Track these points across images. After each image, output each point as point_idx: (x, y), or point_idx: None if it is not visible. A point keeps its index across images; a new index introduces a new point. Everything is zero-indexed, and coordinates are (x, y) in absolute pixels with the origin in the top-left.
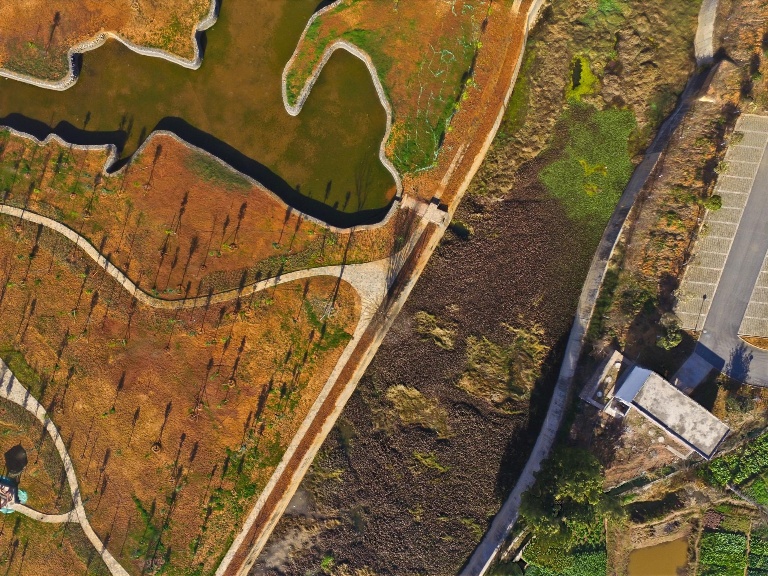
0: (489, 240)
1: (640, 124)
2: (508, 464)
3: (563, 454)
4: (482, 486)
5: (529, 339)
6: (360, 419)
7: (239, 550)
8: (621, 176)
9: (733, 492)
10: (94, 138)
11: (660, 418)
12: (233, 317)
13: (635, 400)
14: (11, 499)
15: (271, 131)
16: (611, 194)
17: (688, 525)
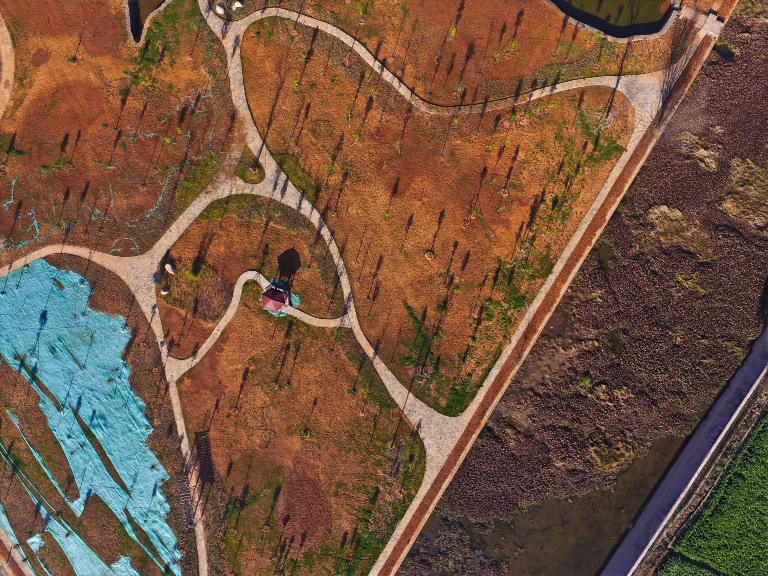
0: (756, 61)
1: None
2: None
3: None
4: (744, 309)
5: None
6: (621, 240)
7: (507, 362)
8: None
9: None
10: None
11: None
12: (508, 125)
13: None
14: (285, 301)
15: None
16: None
17: None
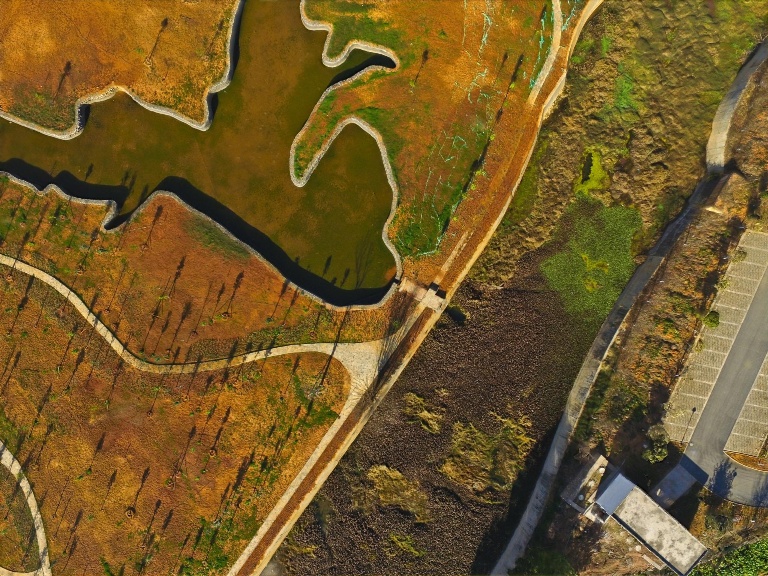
0: (485, 327)
1: (645, 224)
2: (484, 554)
3: (539, 557)
4: (456, 574)
5: (516, 430)
6: (339, 496)
7: None
8: (622, 274)
9: None
10: (95, 191)
11: (639, 533)
12: (220, 386)
13: (616, 513)
14: None
15: (275, 200)
16: (610, 291)
17: None
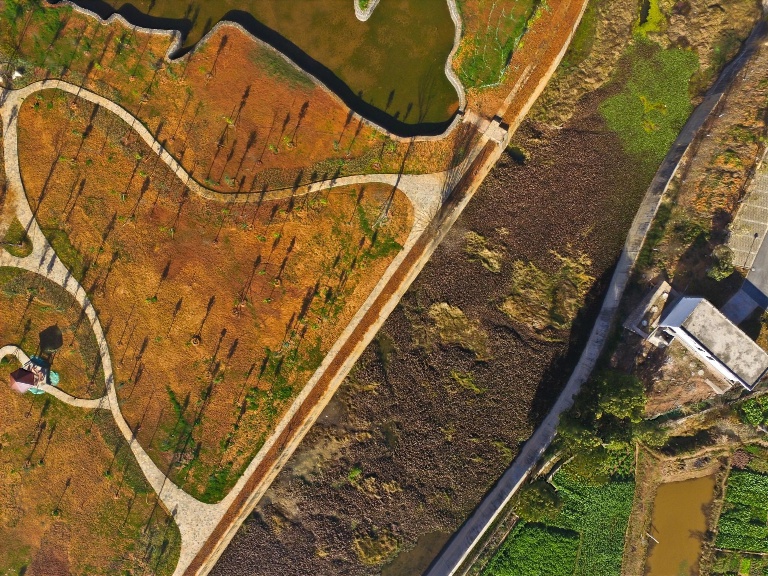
0: (544, 167)
1: (702, 66)
2: (544, 391)
3: (606, 376)
4: (516, 411)
5: (575, 269)
6: (400, 334)
7: (270, 452)
8: (679, 116)
9: (764, 434)
10: (157, 24)
11: (707, 345)
12: (285, 216)
13: (684, 325)
14: (43, 379)
15: (338, 34)
16: (668, 133)
17: (717, 463)
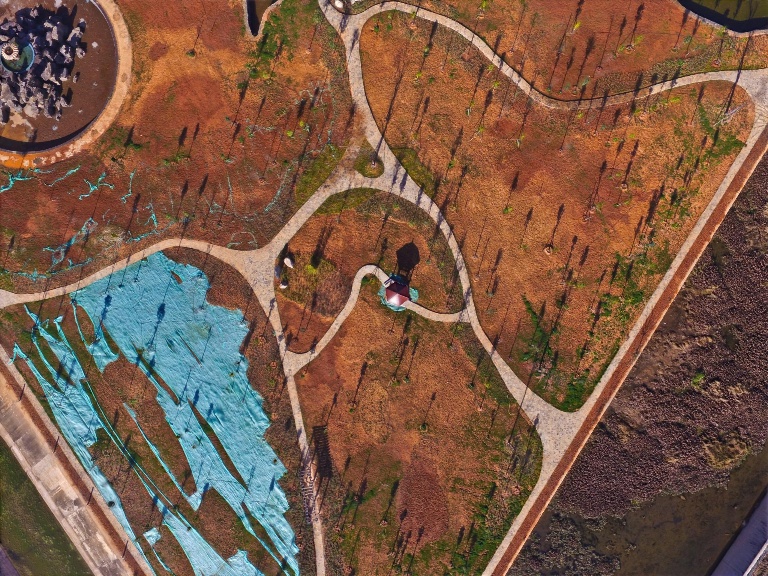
0: None
1: None
2: None
3: None
4: None
5: None
6: (735, 236)
7: (625, 357)
8: None
9: None
10: None
11: None
12: (627, 120)
13: None
14: None
15: None
16: None
17: None
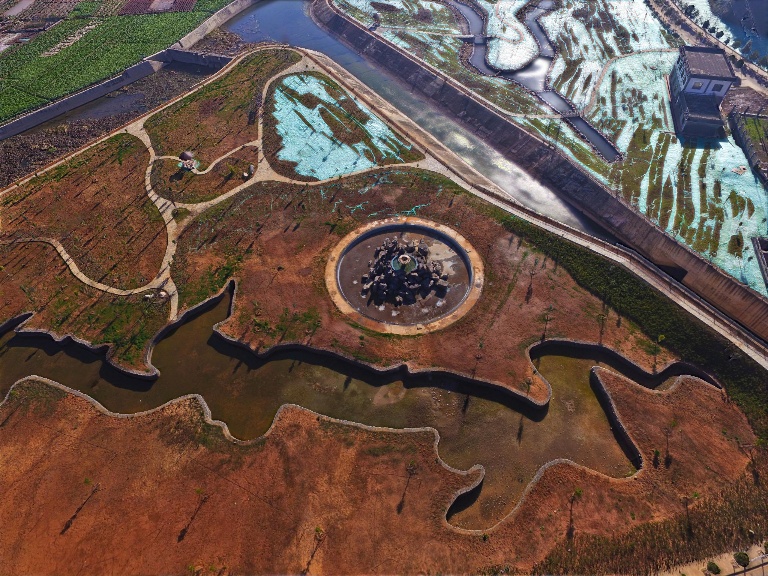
0: None
1: None
2: None
3: None
4: None
5: None
6: None
7: None
8: None
9: None
10: (35, 343)
11: None
12: (7, 233)
13: None
14: None
15: None
16: None
17: None
